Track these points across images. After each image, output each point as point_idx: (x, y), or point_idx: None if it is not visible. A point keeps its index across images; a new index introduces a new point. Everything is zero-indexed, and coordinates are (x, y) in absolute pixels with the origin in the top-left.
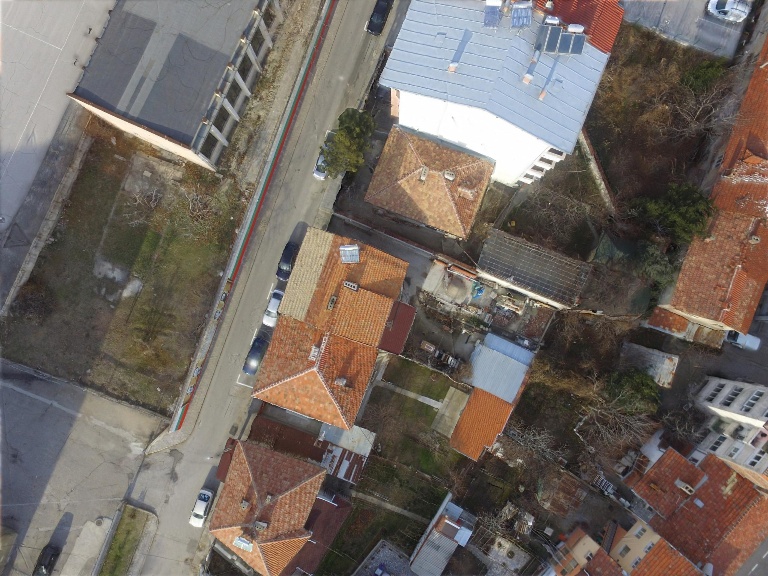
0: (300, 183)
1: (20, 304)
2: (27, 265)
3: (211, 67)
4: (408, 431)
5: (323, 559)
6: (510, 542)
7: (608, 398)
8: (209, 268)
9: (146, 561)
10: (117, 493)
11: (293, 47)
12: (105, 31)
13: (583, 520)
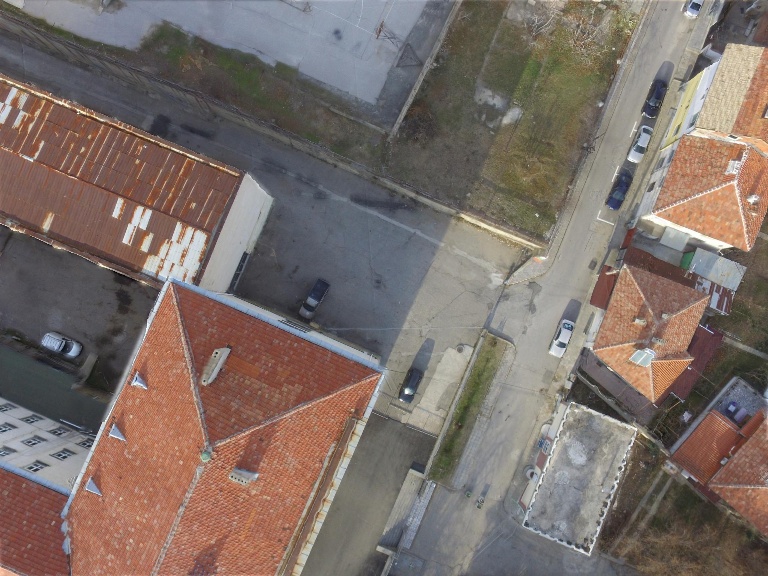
0: (667, 23)
1: (409, 124)
2: (418, 85)
3: None
4: (763, 273)
5: None
6: None
7: None
8: (589, 98)
9: (503, 389)
10: (477, 322)
11: None
12: None
13: None
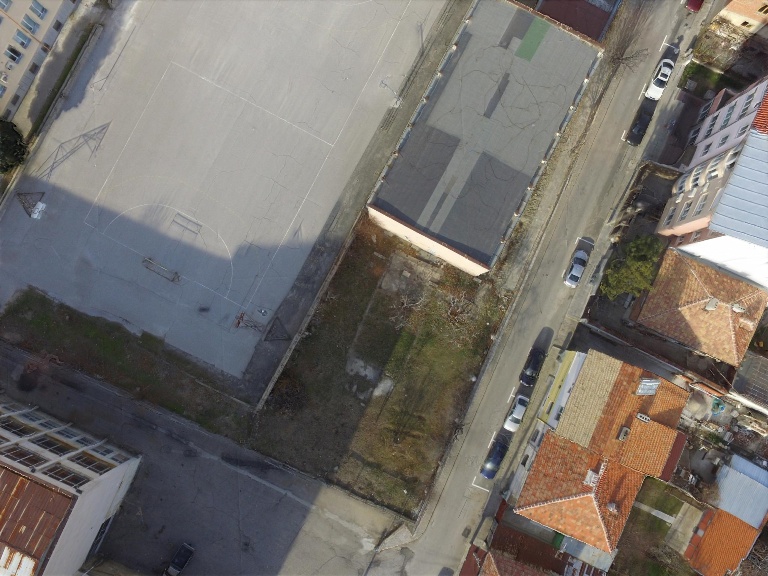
0: (547, 288)
1: (276, 398)
2: (286, 360)
3: (512, 187)
4: (640, 544)
5: None
6: None
7: None
8: (462, 372)
9: None
10: None
11: (560, 157)
12: (407, 144)
13: None
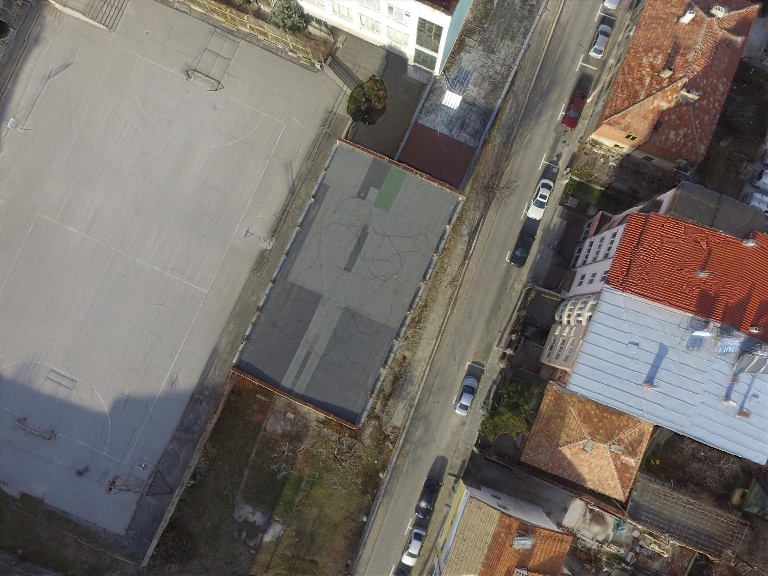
0: (439, 416)
1: (161, 553)
2: (169, 514)
3: (377, 341)
4: None
5: None
6: None
7: None
8: (352, 513)
9: None
10: None
11: (440, 287)
12: (269, 302)
13: None
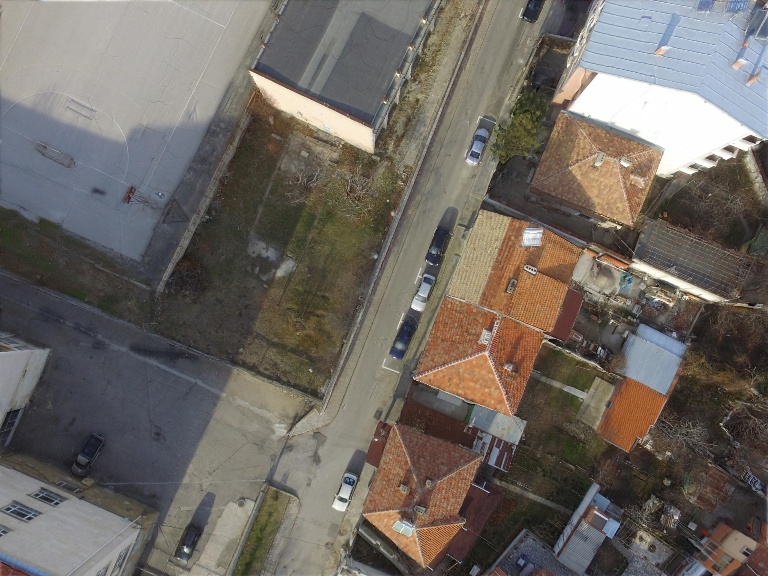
0: (451, 168)
1: (176, 280)
2: (185, 241)
3: (393, 47)
4: None
5: (472, 547)
6: (652, 536)
7: (763, 392)
8: (364, 250)
9: (286, 544)
10: (259, 474)
11: (454, 31)
12: (287, 8)
13: (726, 516)
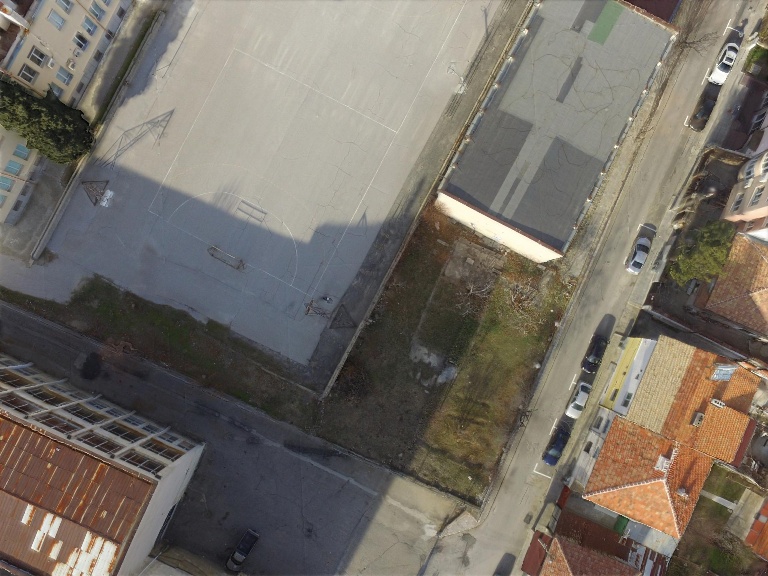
0: (609, 275)
1: (341, 385)
2: (351, 347)
3: (585, 172)
4: (701, 530)
5: None
6: None
7: None
8: (526, 359)
9: None
10: (409, 574)
11: (624, 142)
12: (479, 129)
13: None
